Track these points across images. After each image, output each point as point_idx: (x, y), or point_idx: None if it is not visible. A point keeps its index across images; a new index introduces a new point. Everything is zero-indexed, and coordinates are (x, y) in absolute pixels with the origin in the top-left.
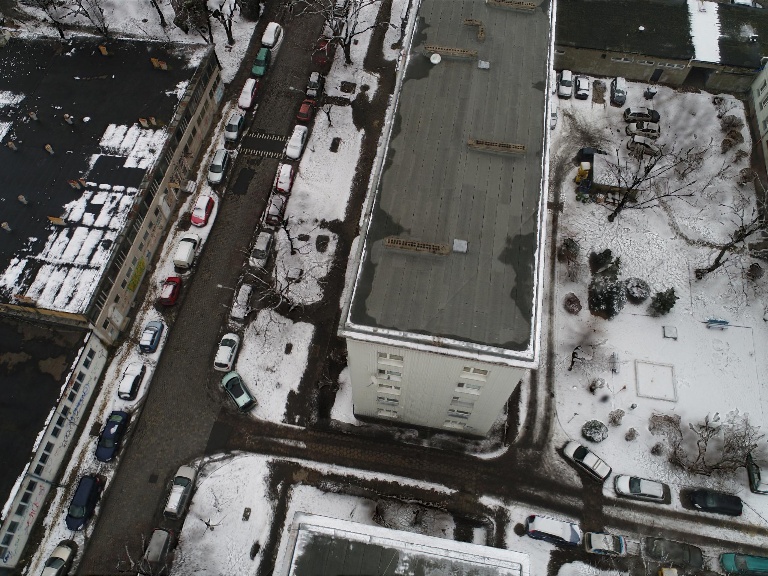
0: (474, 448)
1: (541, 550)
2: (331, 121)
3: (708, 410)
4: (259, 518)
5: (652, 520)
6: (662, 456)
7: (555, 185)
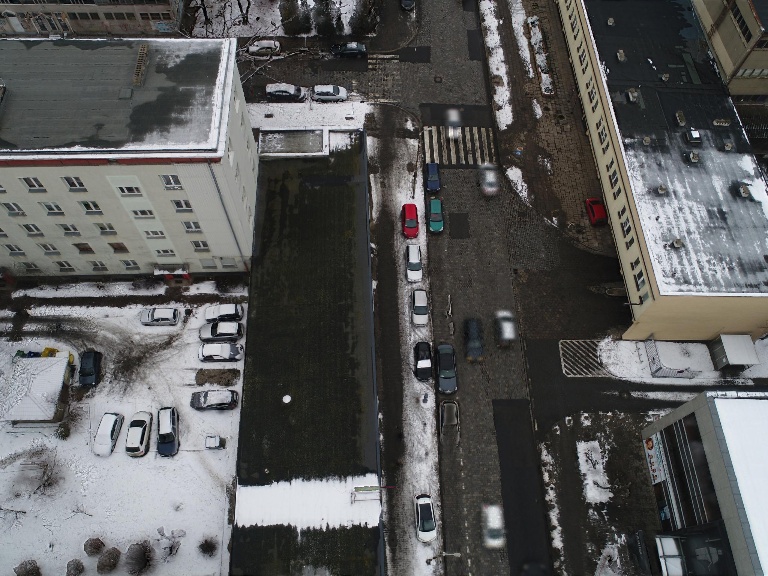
0: None
1: None
2: None
3: None
4: None
5: None
6: None
7: (49, 331)
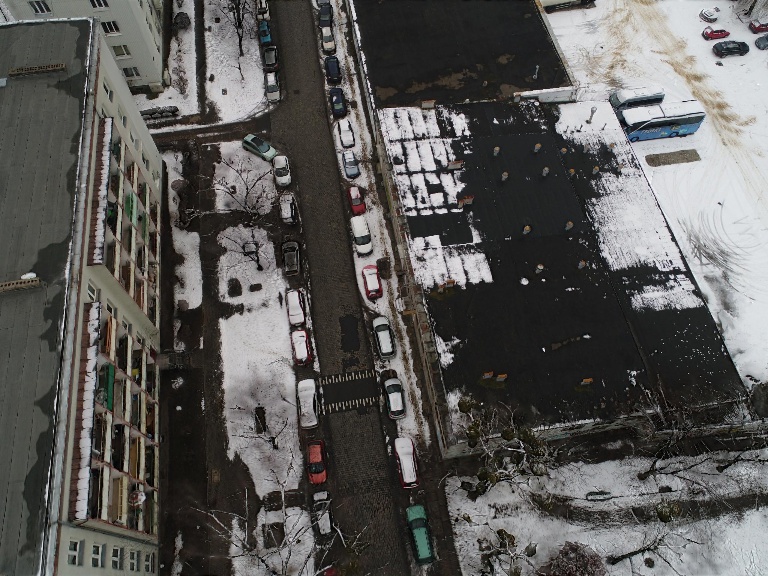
0: None
1: None
2: (278, 457)
3: None
4: (215, 92)
5: None
6: None
7: None
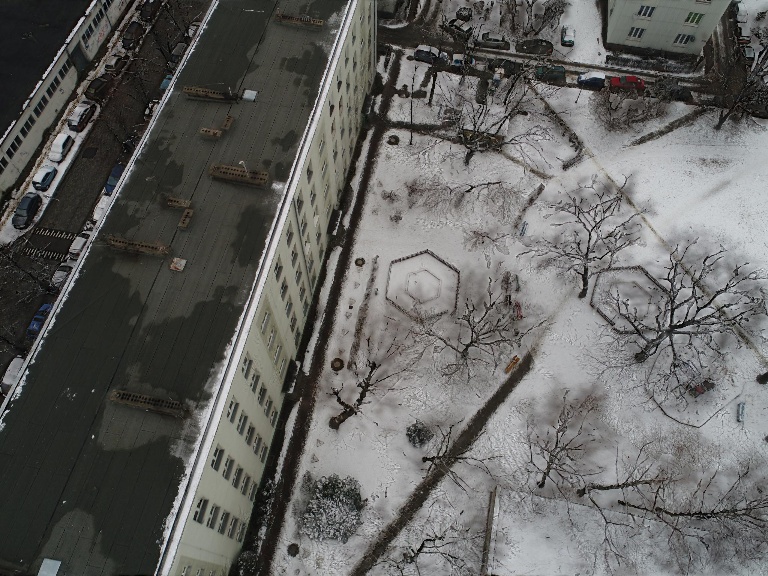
0: (385, 20)
1: (422, 66)
2: None
3: (542, 10)
4: None
5: (496, 57)
6: (505, 23)
7: None
